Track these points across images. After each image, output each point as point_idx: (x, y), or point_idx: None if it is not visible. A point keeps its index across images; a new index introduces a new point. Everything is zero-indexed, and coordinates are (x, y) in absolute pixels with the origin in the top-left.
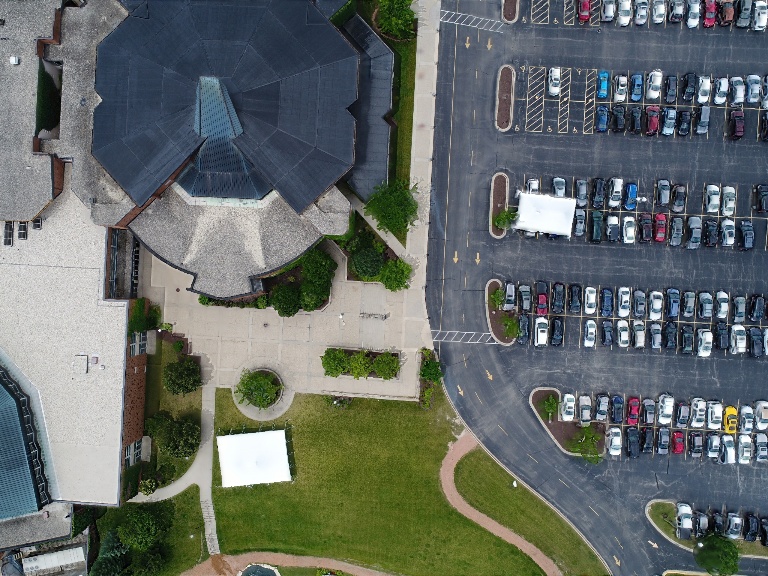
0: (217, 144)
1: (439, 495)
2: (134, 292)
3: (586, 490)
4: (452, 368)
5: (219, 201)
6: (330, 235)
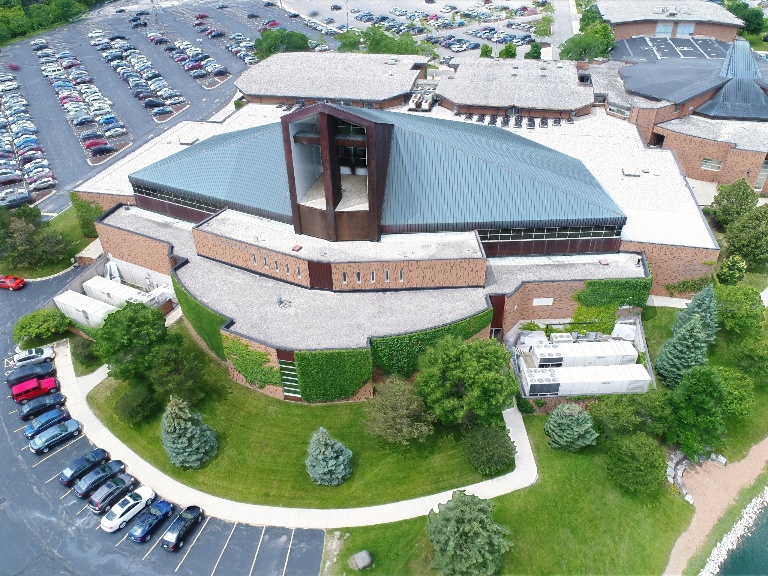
0: (740, 83)
1: None
2: None
3: None
4: None
5: None
6: None
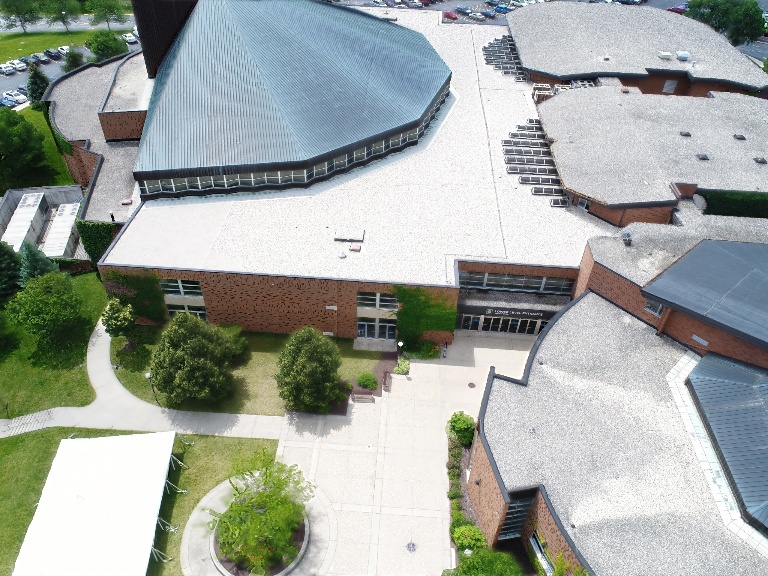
0: None
1: None
2: (463, 322)
3: None
4: None
5: (697, 429)
6: None
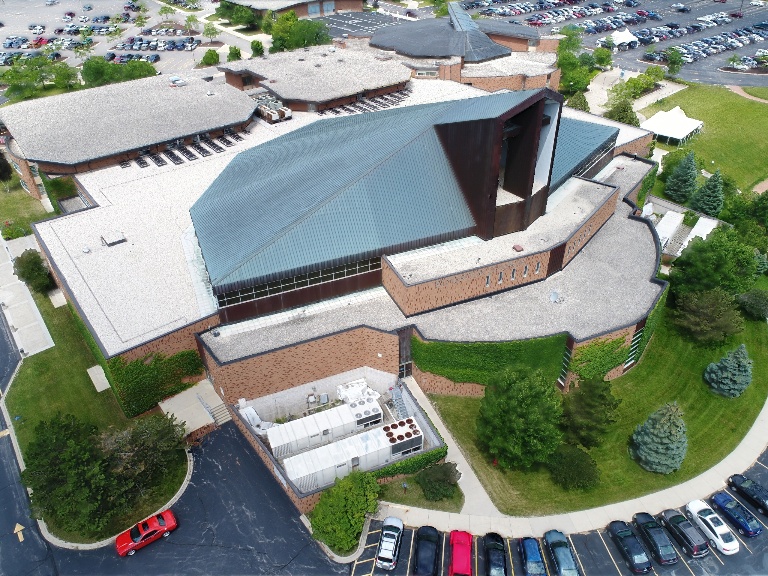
0: (473, 33)
1: (767, 104)
2: None
3: None
4: None
5: (492, 61)
6: (561, 40)
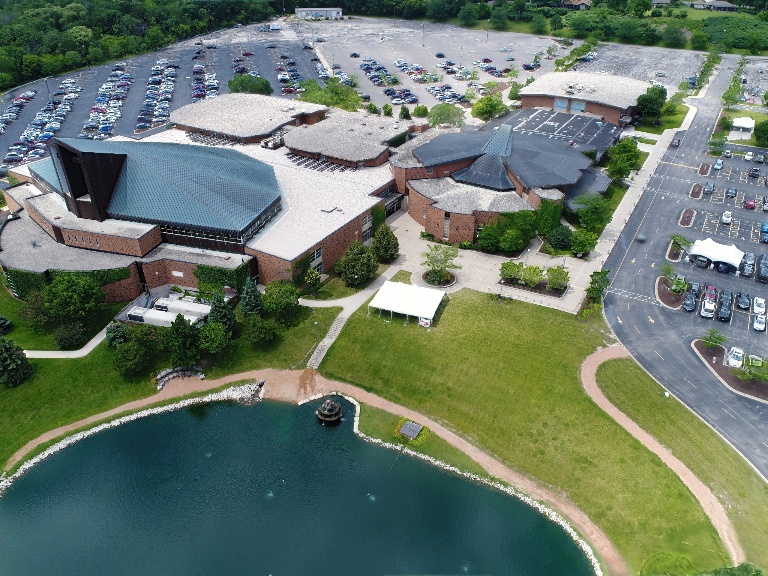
0: (491, 157)
1: (575, 380)
2: None
3: (758, 427)
4: (615, 307)
5: (472, 187)
6: (545, 200)
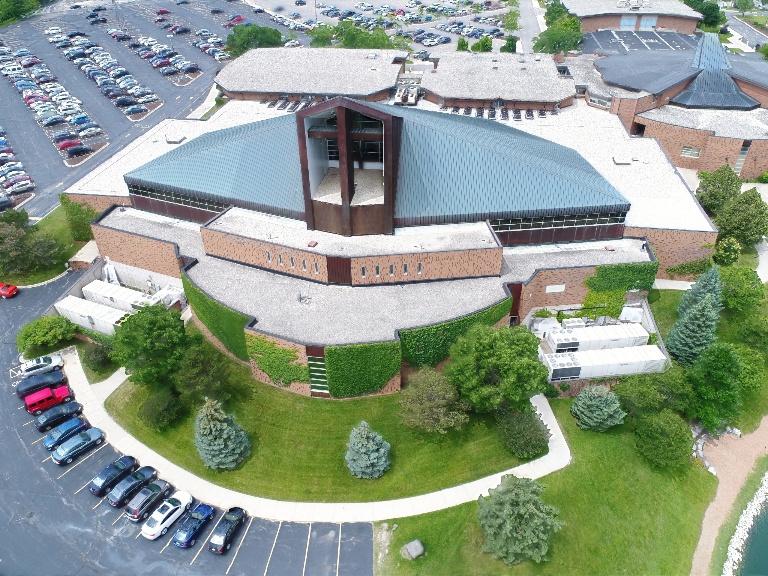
0: (712, 73)
1: None
2: None
3: None
4: None
5: None
6: None
